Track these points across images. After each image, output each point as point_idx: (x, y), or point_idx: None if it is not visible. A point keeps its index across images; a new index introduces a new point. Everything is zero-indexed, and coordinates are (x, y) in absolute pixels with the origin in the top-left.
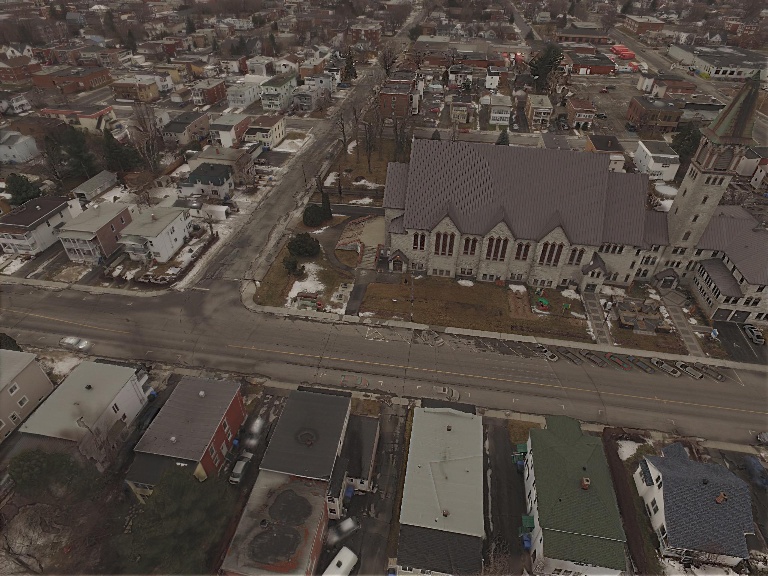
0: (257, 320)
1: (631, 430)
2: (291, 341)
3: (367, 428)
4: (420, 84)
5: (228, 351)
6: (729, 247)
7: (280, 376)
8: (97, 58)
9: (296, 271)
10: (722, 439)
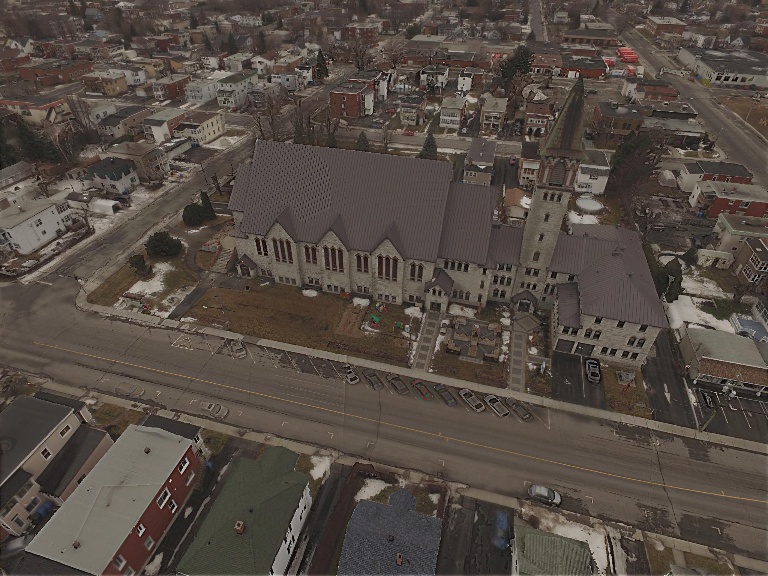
0: (77, 318)
1: (390, 468)
2: (96, 342)
3: (89, 441)
4: (381, 84)
5: (30, 348)
6: (583, 271)
7: (63, 378)
8: (90, 52)
9: (145, 270)
10: (488, 488)
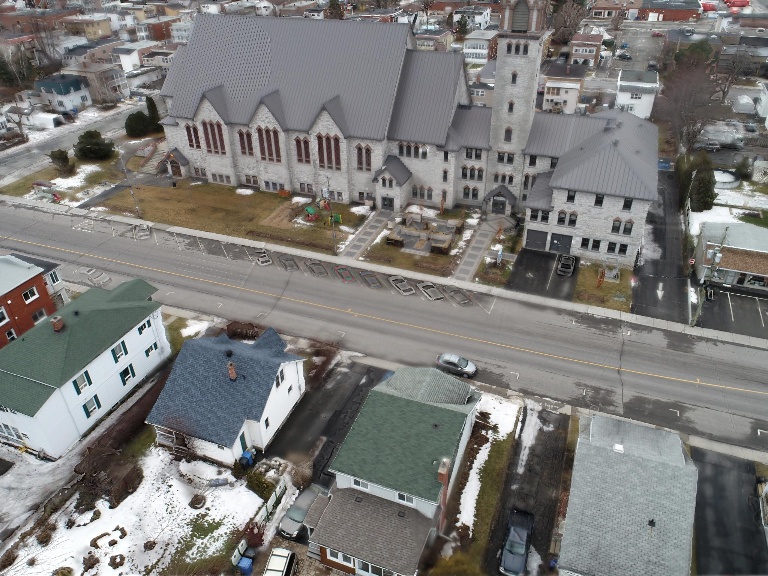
0: None
1: None
2: None
3: None
4: (400, 21)
5: None
6: (567, 152)
7: None
8: (81, 4)
9: None
10: (389, 358)
